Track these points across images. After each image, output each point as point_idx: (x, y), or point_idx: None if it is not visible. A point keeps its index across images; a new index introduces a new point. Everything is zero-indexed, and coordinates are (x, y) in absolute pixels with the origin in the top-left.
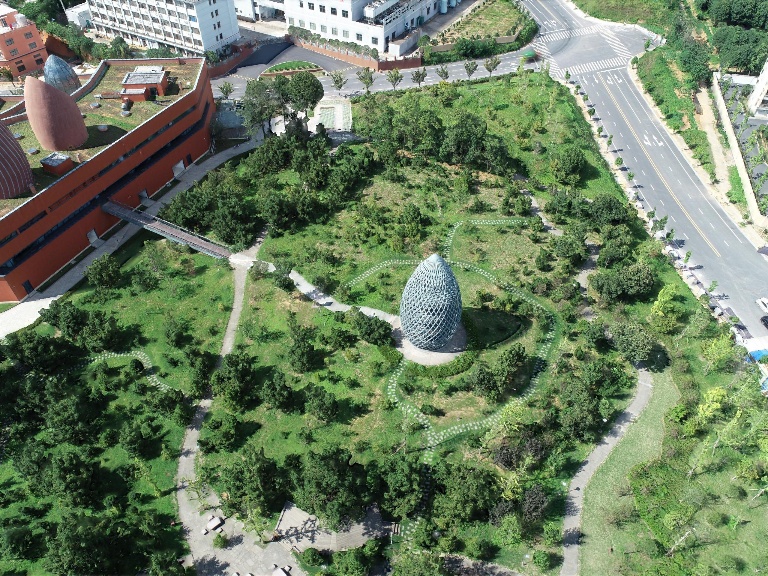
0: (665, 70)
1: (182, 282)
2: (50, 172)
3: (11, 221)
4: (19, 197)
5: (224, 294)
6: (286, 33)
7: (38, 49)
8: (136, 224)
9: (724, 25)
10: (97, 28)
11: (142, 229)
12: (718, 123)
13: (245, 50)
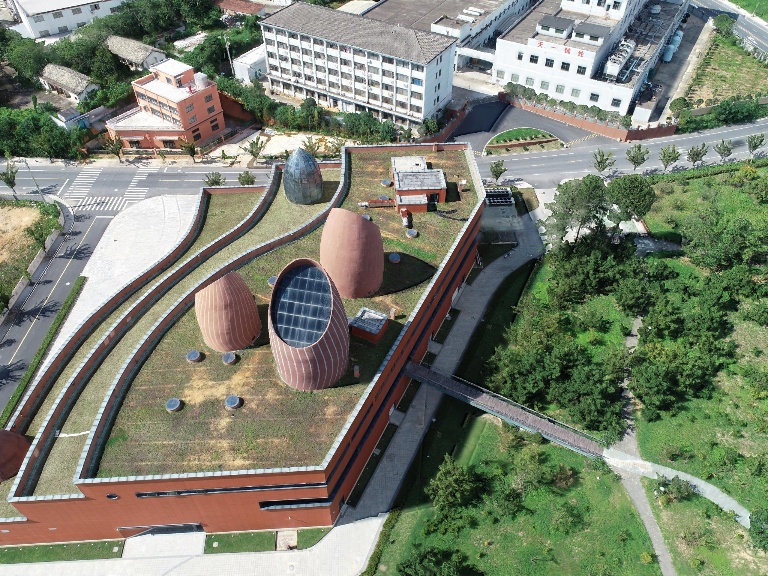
0: None
1: (555, 499)
2: (362, 337)
3: (349, 432)
4: (340, 385)
5: (632, 527)
6: (493, 88)
7: (216, 113)
8: (457, 398)
9: None
10: (271, 83)
11: (449, 395)
12: None
13: (460, 114)
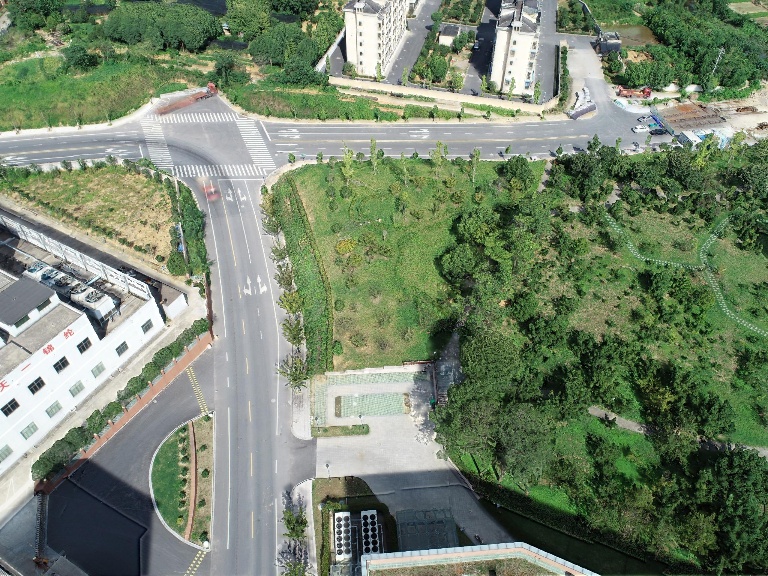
0: (304, 95)
1: None
2: None
3: None
4: None
5: None
6: None
7: None
8: None
9: (216, 45)
10: None
11: None
12: (395, 94)
13: None
